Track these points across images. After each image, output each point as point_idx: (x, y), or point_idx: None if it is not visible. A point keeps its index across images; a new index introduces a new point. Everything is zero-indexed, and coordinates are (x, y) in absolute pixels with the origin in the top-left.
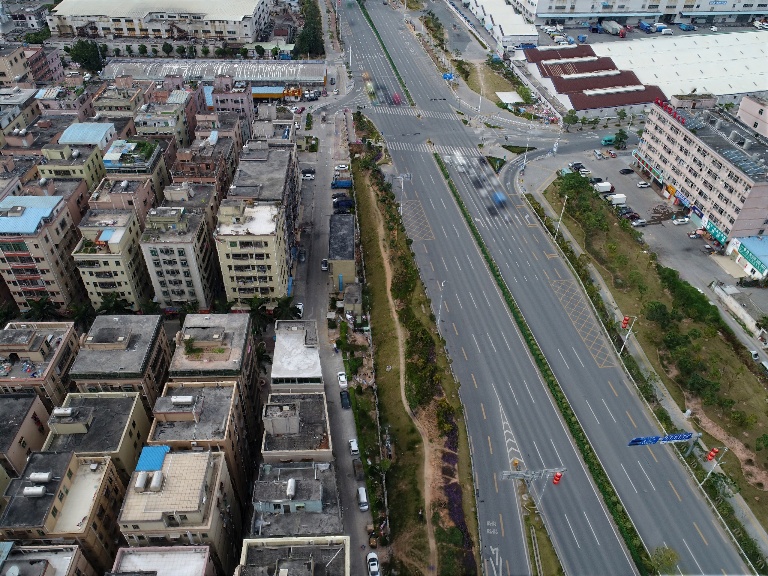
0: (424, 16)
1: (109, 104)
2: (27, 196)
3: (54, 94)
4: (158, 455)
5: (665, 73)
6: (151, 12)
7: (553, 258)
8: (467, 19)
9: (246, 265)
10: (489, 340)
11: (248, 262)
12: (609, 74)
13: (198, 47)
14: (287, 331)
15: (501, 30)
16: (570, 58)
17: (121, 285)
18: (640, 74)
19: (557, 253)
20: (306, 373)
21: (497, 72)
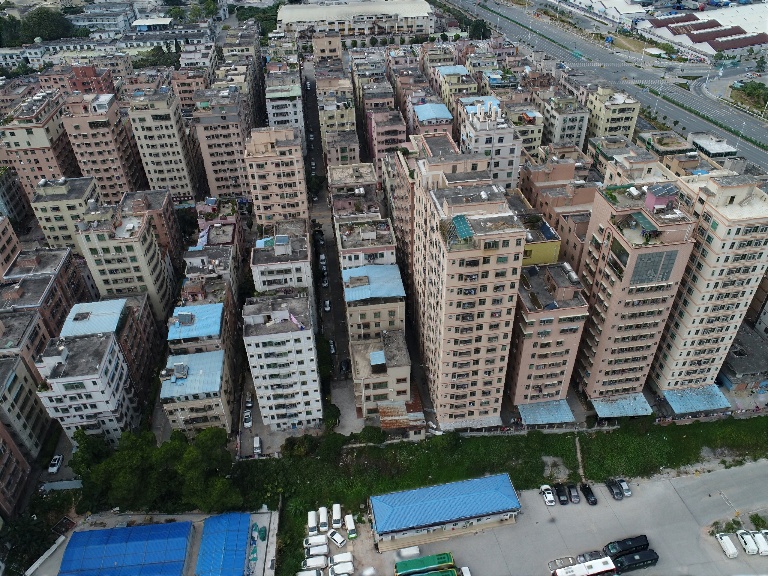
0: (540, 9)
1: (439, 57)
2: (471, 97)
3: (402, 53)
4: (703, 172)
5: (762, 26)
6: (354, 16)
7: (767, 127)
8: (576, 8)
9: (617, 126)
10: (764, 163)
11: (618, 124)
12: (724, 29)
13: (396, 39)
14: (700, 136)
15: (617, 10)
16: (688, 21)
17: (534, 148)
18: (745, 27)
19: (767, 124)
20: (728, 150)
21: (631, 38)
